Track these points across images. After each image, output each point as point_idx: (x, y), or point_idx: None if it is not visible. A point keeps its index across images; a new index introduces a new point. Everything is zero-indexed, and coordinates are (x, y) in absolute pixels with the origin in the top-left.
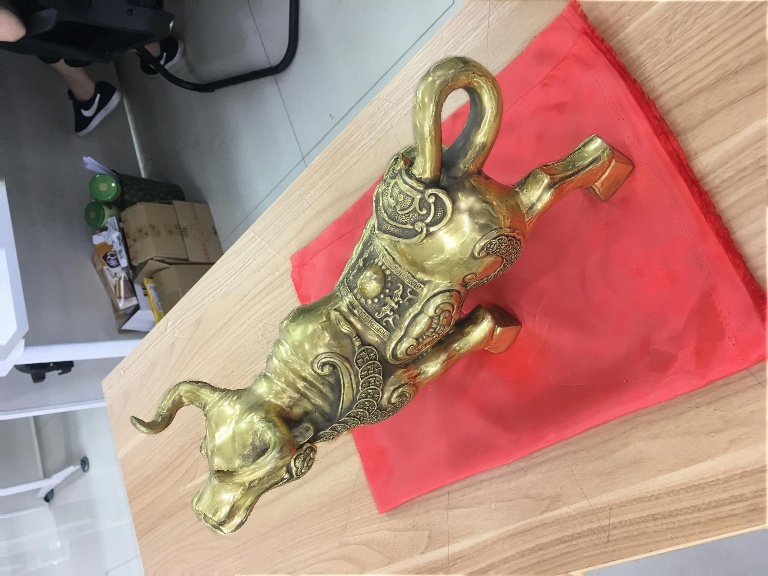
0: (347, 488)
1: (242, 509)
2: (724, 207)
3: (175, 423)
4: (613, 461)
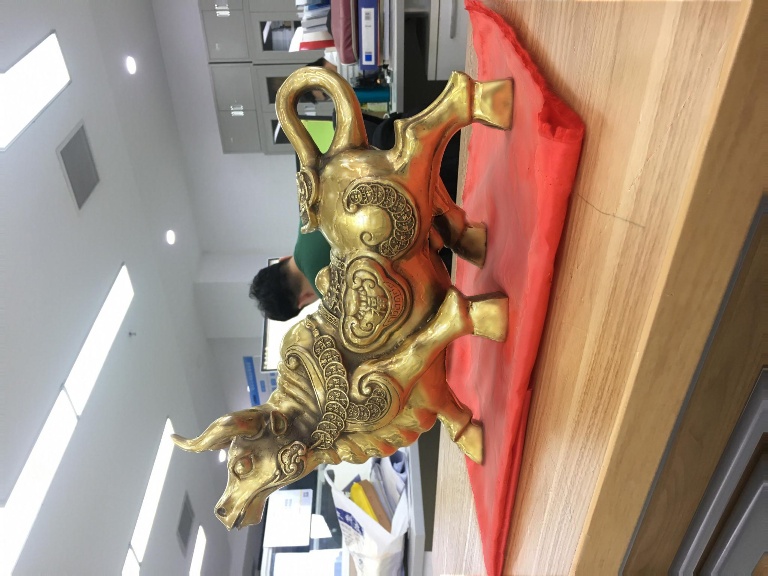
0: None
1: (239, 501)
2: (542, 52)
3: (447, 573)
4: (556, 401)
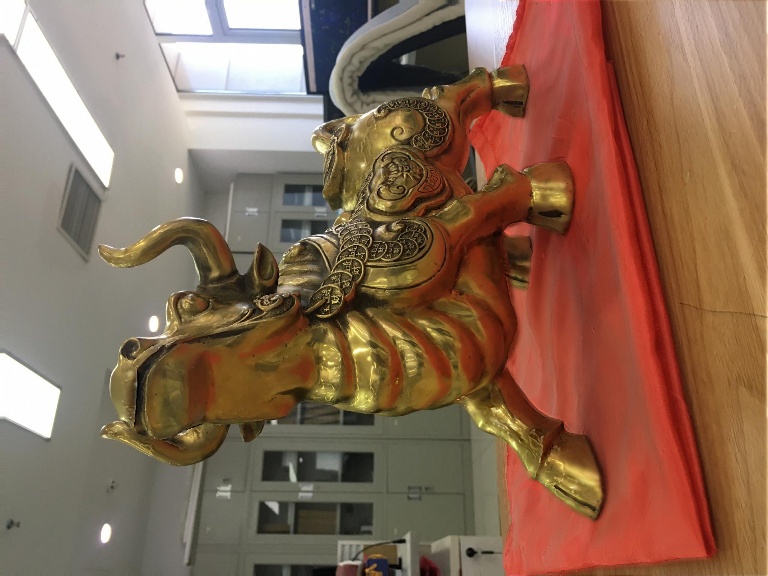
0: None
1: None
2: None
3: None
4: None
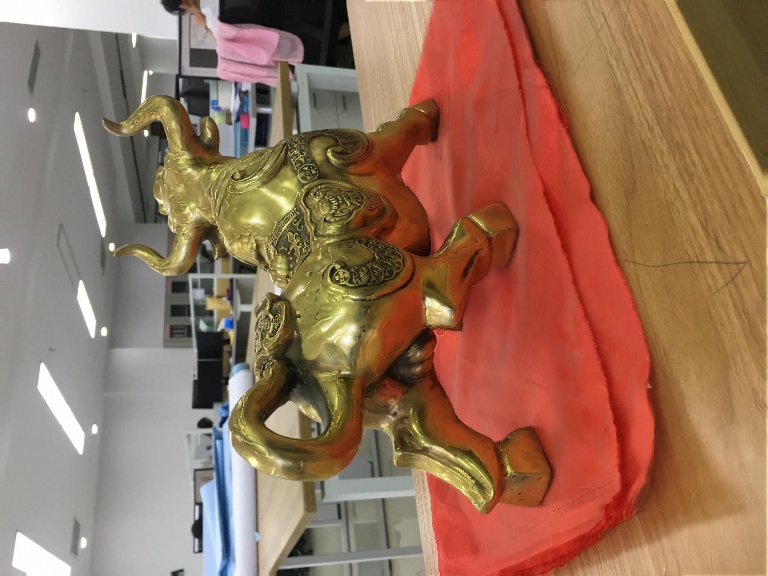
0: (397, 116)
1: None
2: None
3: None
4: None
